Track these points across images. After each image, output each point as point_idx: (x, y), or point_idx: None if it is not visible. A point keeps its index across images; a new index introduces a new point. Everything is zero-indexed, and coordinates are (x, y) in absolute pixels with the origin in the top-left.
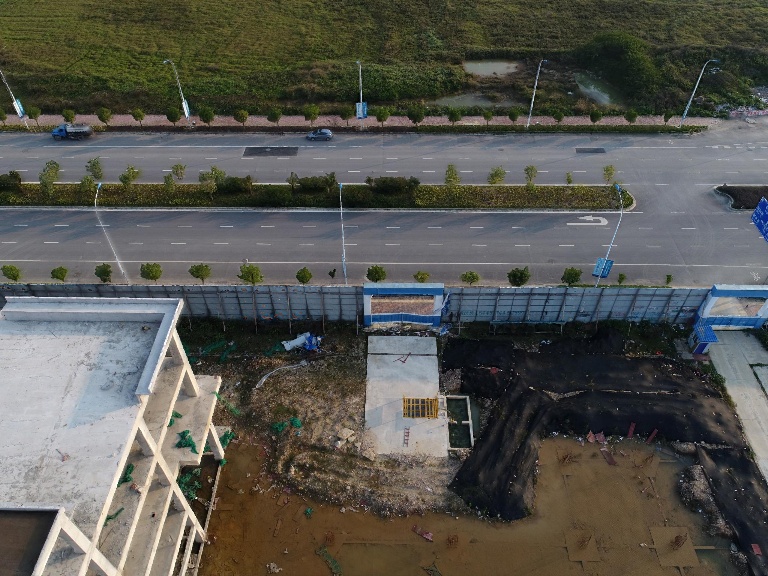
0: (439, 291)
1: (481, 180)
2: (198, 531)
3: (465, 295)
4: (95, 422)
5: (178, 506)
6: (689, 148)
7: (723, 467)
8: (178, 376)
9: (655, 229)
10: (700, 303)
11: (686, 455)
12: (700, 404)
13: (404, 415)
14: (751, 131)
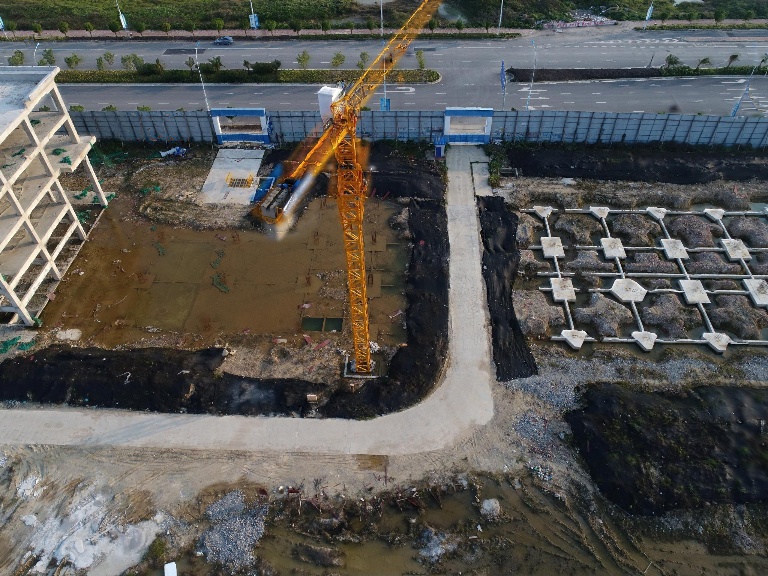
0: (261, 113)
1: (334, 67)
2: (79, 228)
3: (281, 117)
4: (0, 114)
5: (61, 199)
6: (500, 48)
7: (424, 209)
8: (60, 119)
9: (447, 94)
10: (442, 124)
11: (404, 205)
12: (421, 177)
13: (228, 186)
14: (555, 37)
